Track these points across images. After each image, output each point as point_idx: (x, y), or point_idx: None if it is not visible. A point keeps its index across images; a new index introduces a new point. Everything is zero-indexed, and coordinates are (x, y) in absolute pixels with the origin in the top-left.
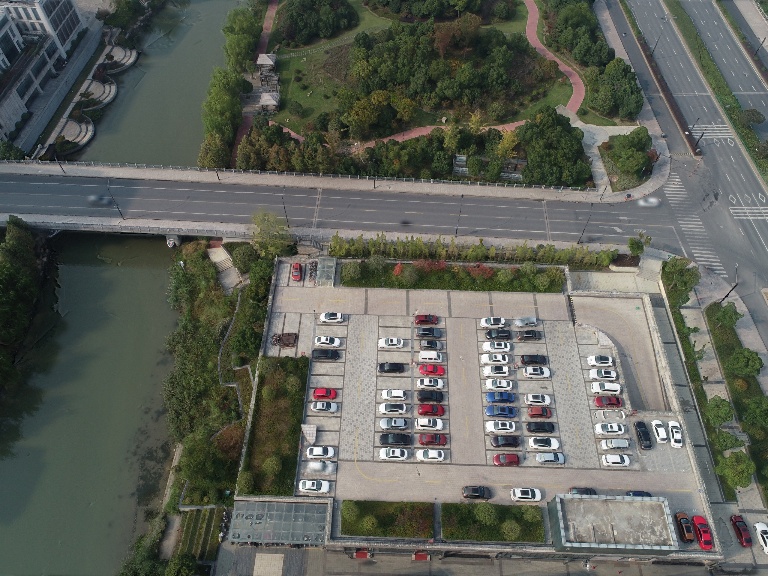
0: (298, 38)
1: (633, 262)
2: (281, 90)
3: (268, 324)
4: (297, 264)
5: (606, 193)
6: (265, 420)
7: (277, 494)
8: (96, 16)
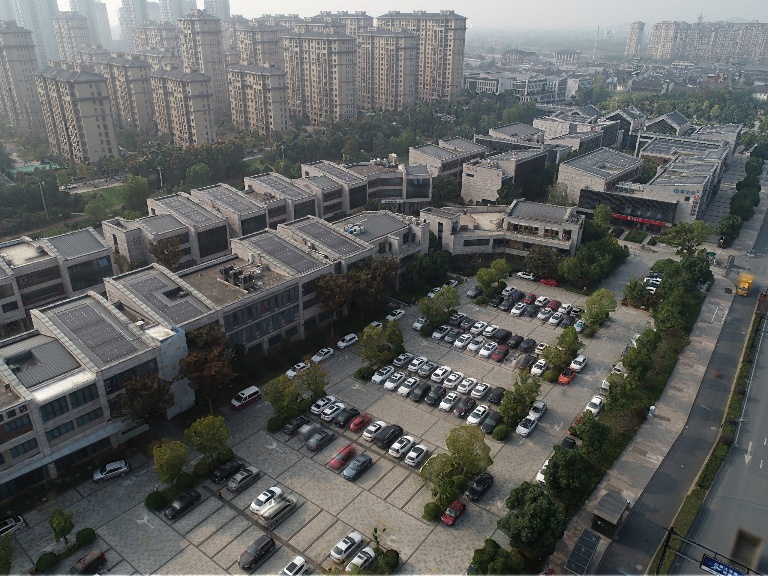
0: None
1: None
2: None
3: None
4: None
5: (754, 129)
6: None
7: None
8: (571, 97)
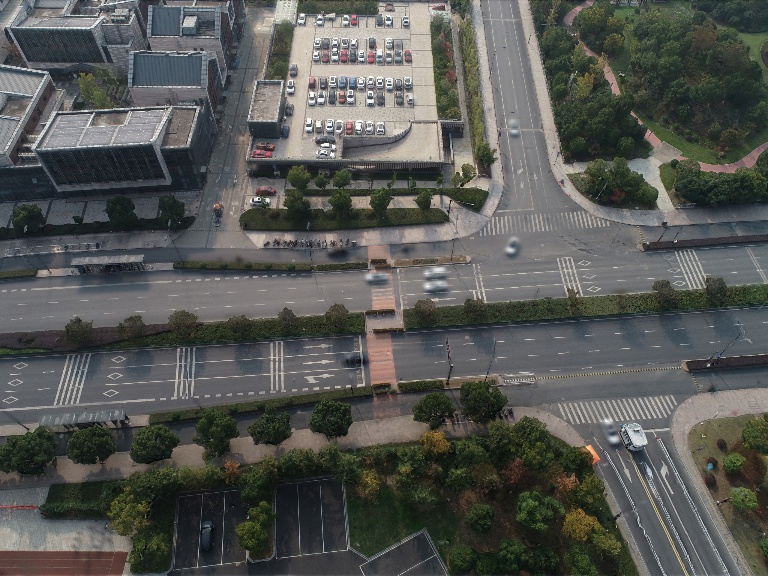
0: (699, 1)
1: (482, 171)
2: (634, 7)
3: (400, 1)
4: (443, 4)
5: (563, 169)
6: (339, 3)
7: (298, 7)
8: None
